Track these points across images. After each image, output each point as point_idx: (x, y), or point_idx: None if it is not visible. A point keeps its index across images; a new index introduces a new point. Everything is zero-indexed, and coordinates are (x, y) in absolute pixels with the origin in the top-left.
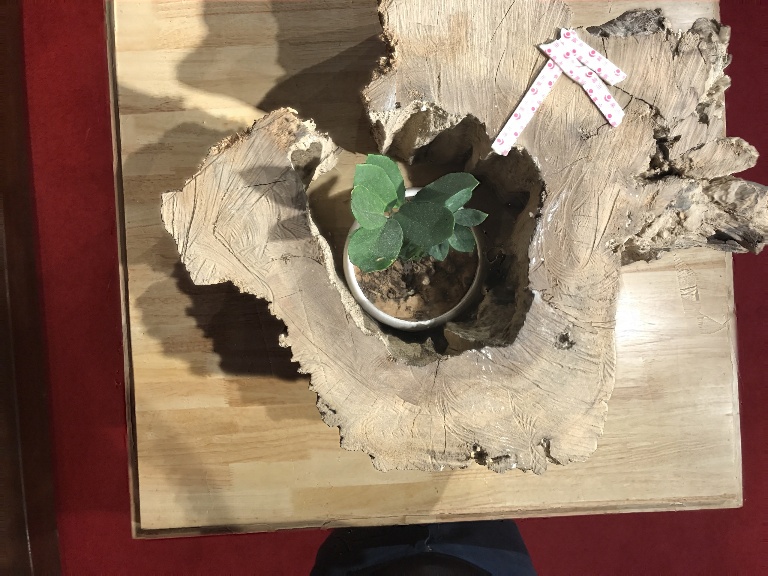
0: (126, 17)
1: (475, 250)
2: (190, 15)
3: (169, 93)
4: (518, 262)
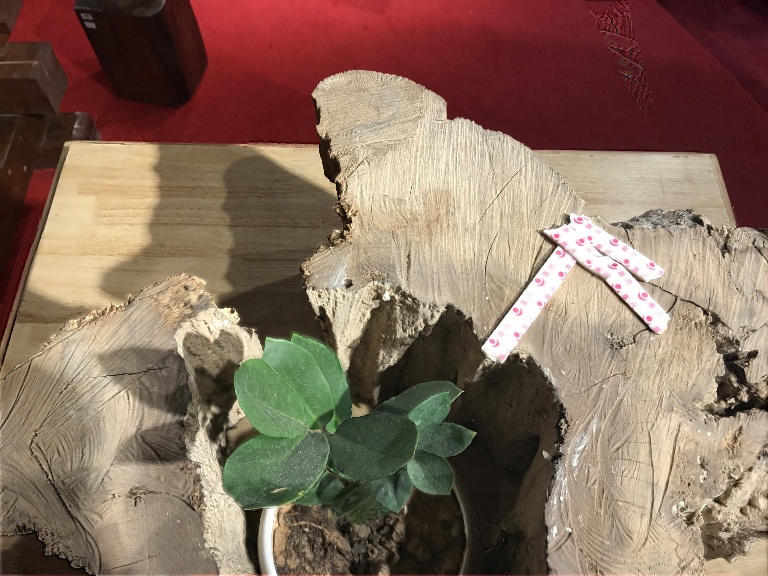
0: (60, 220)
1: (461, 526)
2: (134, 223)
3: (85, 302)
4: (528, 539)
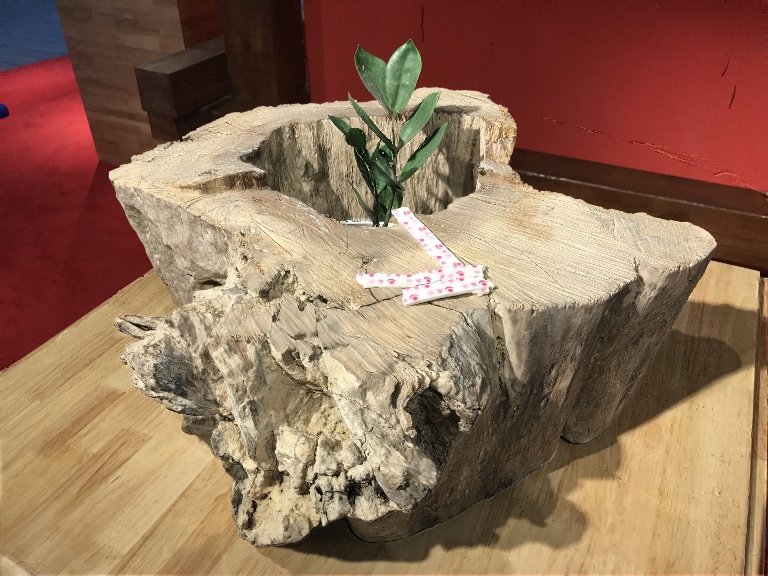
0: None
1: None
2: None
3: None
4: None
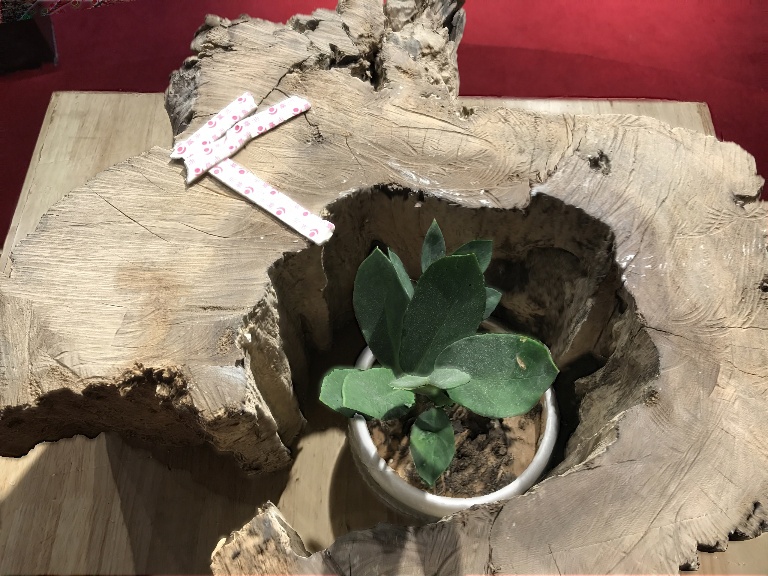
0: None
1: None
2: None
3: None
4: None
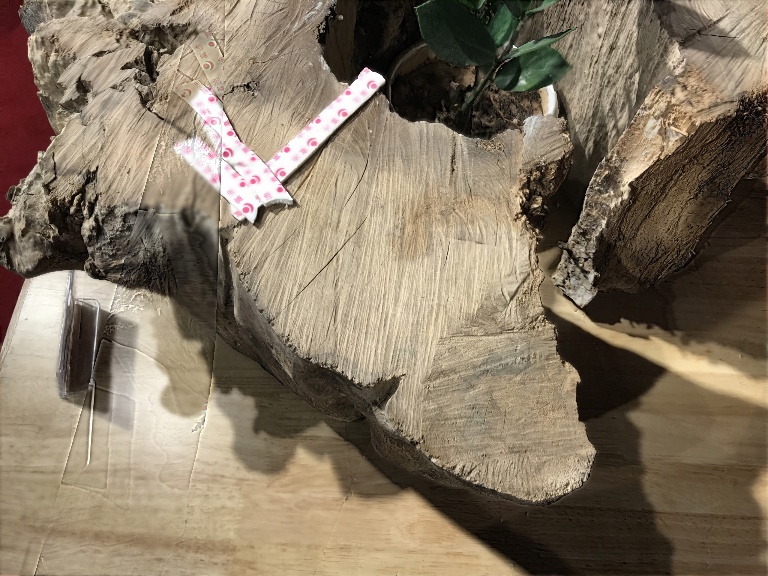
0: None
1: None
2: None
3: None
4: None
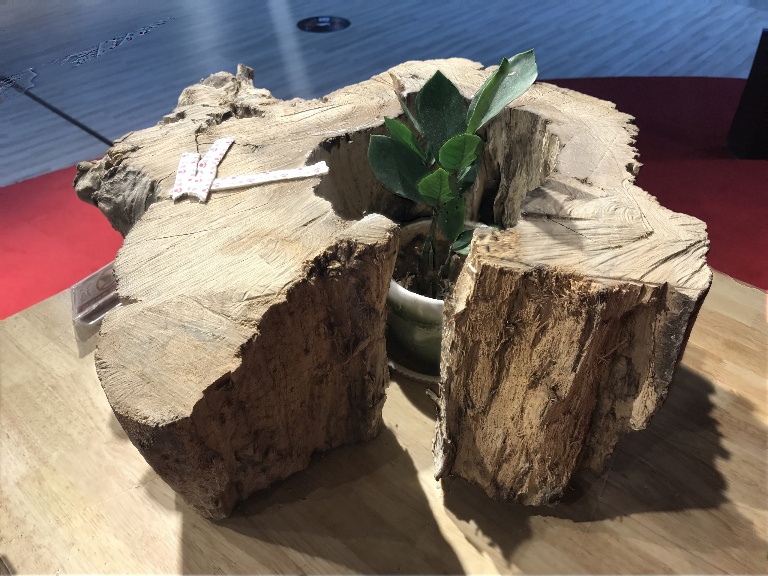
0: None
1: None
2: None
3: None
4: None
